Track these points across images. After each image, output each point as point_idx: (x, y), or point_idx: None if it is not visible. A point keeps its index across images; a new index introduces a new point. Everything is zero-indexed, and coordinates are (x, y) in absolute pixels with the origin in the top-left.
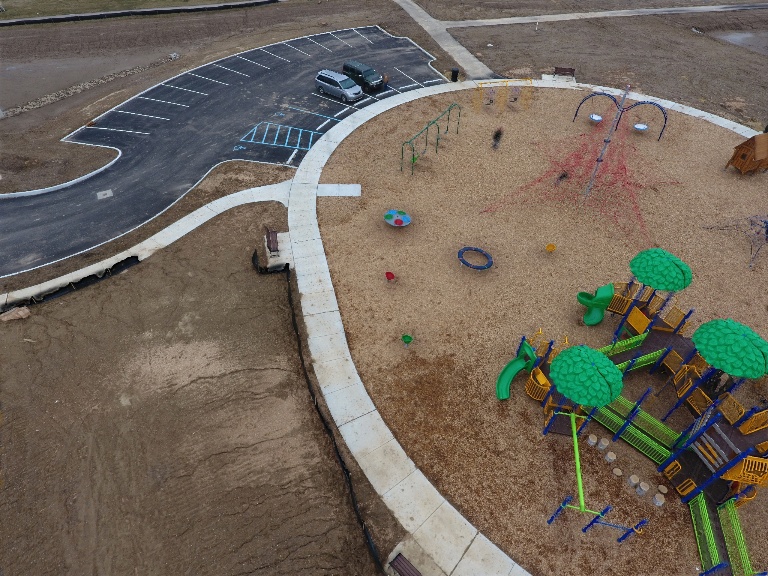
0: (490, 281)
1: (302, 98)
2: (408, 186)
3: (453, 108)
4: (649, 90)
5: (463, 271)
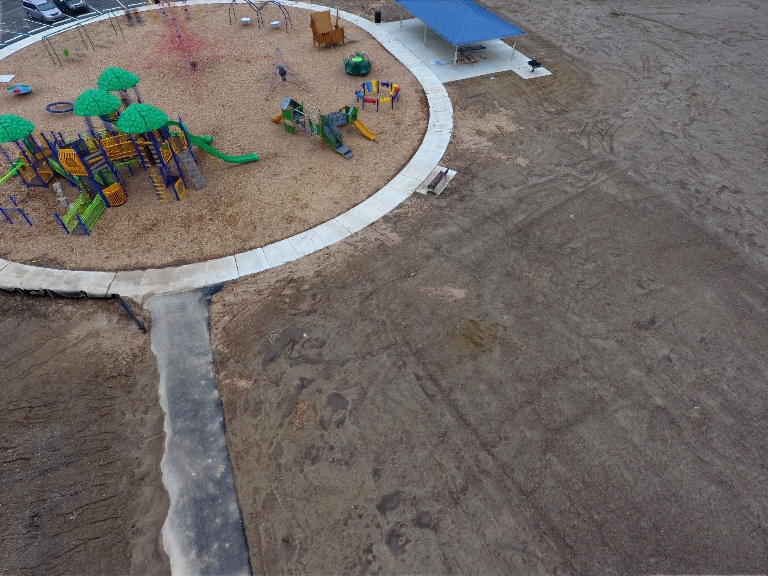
0: (65, 120)
1: (11, 23)
2: (53, 73)
3: (137, 21)
4: (316, 0)
5: (50, 117)
